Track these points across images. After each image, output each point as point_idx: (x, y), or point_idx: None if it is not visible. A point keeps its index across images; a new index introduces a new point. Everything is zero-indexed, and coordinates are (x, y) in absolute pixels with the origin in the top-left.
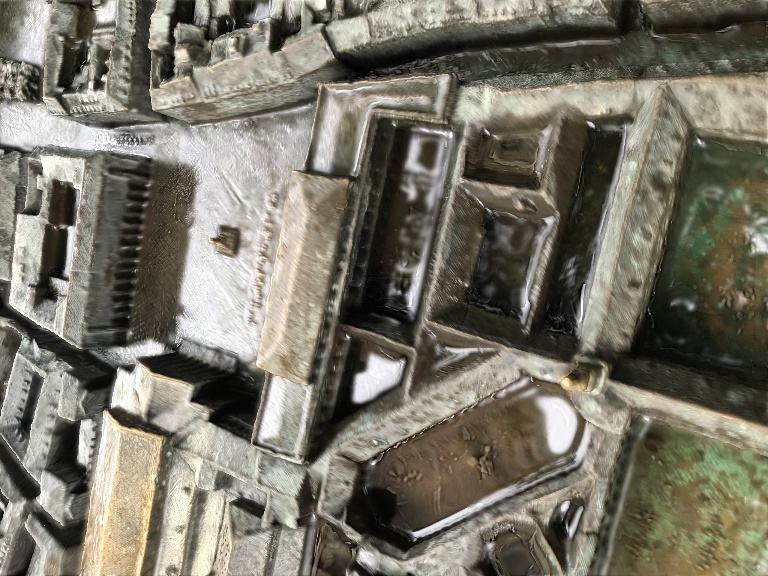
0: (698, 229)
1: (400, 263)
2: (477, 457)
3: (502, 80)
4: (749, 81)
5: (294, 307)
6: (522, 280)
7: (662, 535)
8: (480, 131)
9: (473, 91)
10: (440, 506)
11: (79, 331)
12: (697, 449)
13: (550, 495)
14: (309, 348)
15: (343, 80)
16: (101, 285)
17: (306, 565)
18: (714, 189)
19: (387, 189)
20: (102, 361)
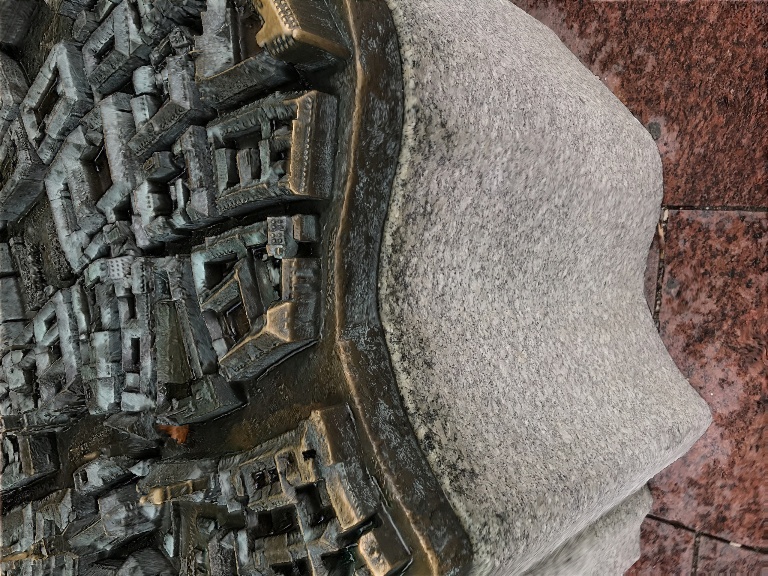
0: None
1: None
2: None
3: None
4: None
5: None
6: None
7: None
8: None
9: None
10: None
11: None
12: None
13: None
14: None
15: (7, 52)
16: None
17: None
18: None
19: None
20: None
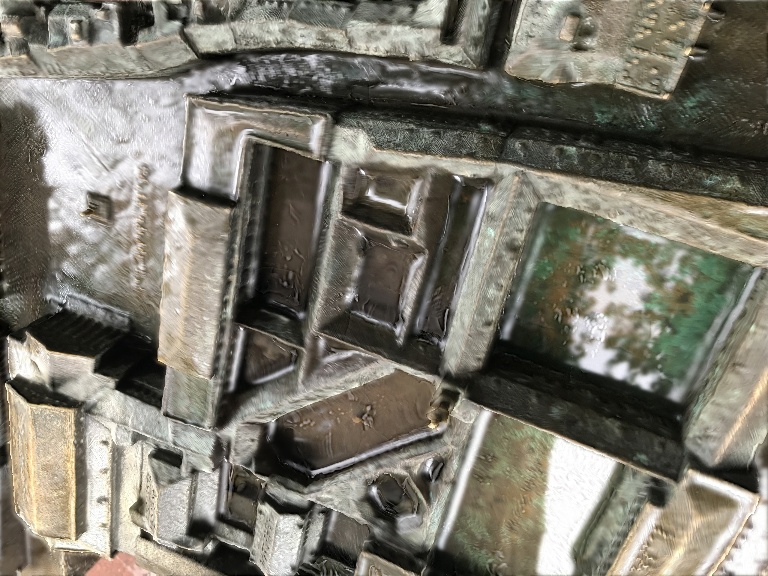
0: (542, 259)
1: (284, 256)
2: (360, 416)
3: (376, 128)
4: (588, 186)
5: (189, 320)
6: None
7: (499, 469)
8: (356, 170)
9: (348, 133)
10: (332, 450)
11: None
12: None
13: (418, 456)
14: (208, 352)
15: (207, 68)
16: None
17: (223, 491)
18: (557, 228)
19: (266, 191)
20: None
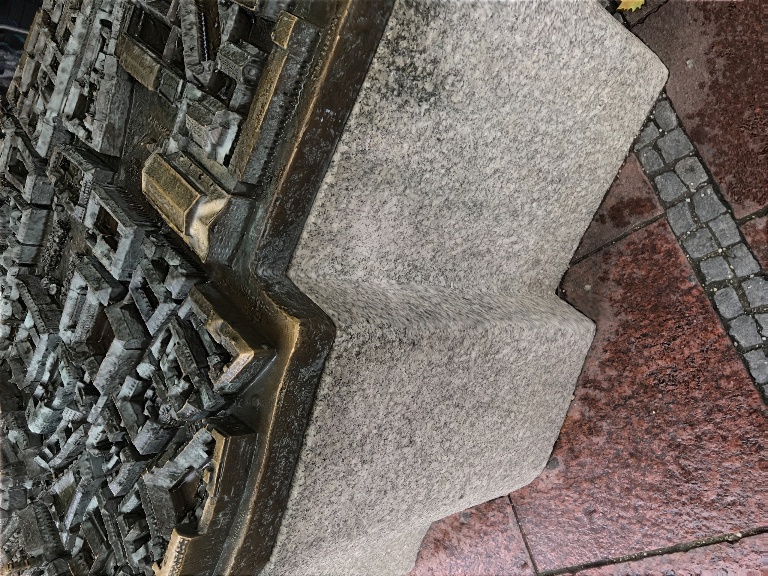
0: None
1: None
2: None
3: None
4: None
5: None
6: None
7: None
8: None
9: None
10: None
11: None
12: None
13: None
14: None
15: None
16: None
17: None
18: None
19: None
20: None
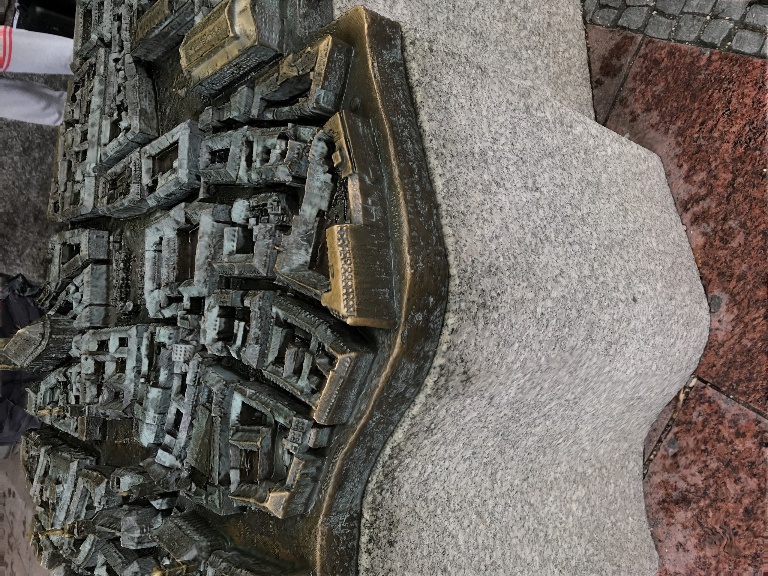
0: None
1: None
2: None
3: None
4: None
5: None
6: None
7: None
8: None
9: None
10: None
11: None
12: None
13: None
14: None
15: (146, 68)
16: None
17: None
18: None
19: None
20: None
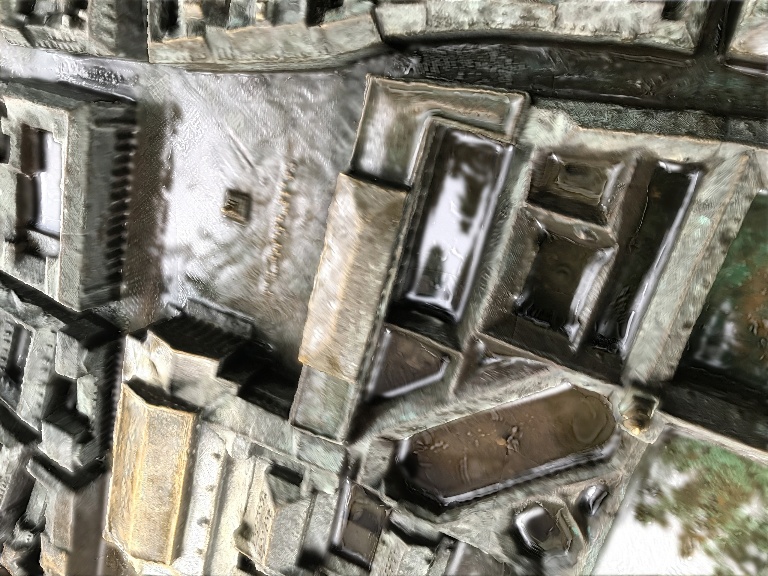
0: (739, 262)
1: (438, 257)
2: (506, 438)
3: (578, 108)
4: None
5: (344, 313)
6: (568, 294)
7: (664, 506)
8: (547, 155)
9: (545, 114)
10: (468, 475)
11: (75, 294)
12: (705, 444)
13: (580, 482)
14: (358, 351)
15: (382, 57)
16: (94, 245)
17: (338, 518)
18: (760, 228)
19: None
20: (92, 312)
